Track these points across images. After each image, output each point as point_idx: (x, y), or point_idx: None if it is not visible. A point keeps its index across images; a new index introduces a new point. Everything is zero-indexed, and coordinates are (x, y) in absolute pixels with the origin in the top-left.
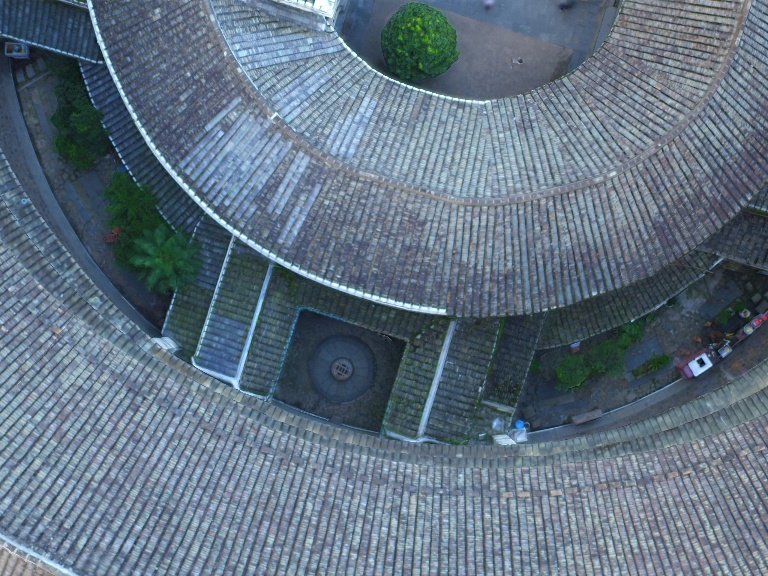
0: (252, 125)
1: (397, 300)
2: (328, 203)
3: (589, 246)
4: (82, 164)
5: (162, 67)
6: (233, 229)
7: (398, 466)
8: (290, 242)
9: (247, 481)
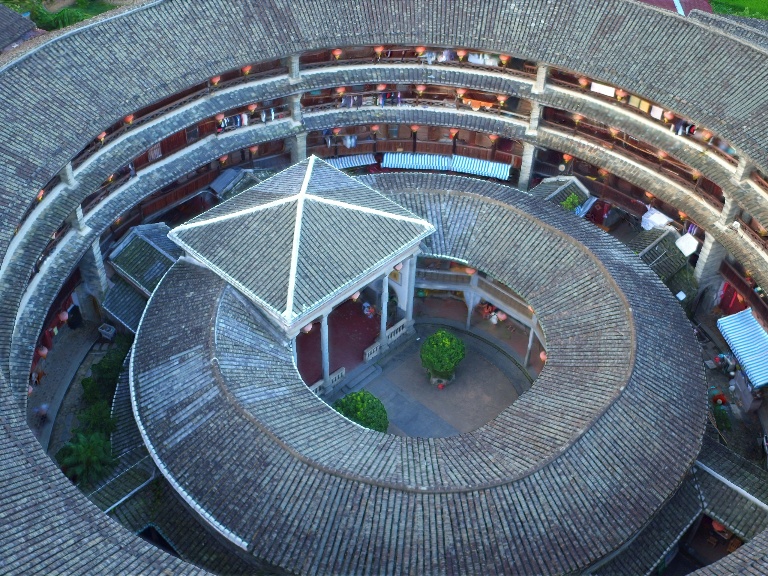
0: (199, 362)
1: (217, 520)
2: (212, 426)
3: (384, 543)
4: (89, 397)
5: (172, 320)
6: (141, 425)
7: (108, 519)
8: (171, 446)
9: (0, 465)
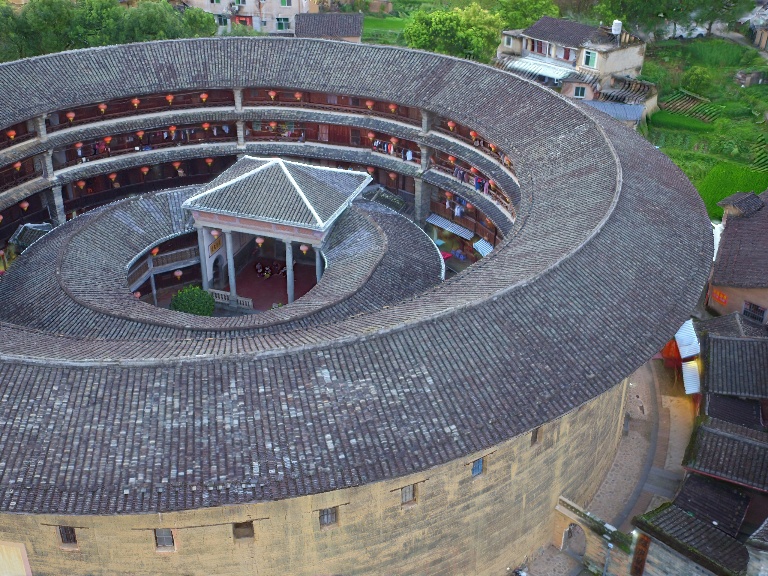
0: None
1: None
2: None
3: None
4: None
5: None
6: None
7: None
8: None
9: None
